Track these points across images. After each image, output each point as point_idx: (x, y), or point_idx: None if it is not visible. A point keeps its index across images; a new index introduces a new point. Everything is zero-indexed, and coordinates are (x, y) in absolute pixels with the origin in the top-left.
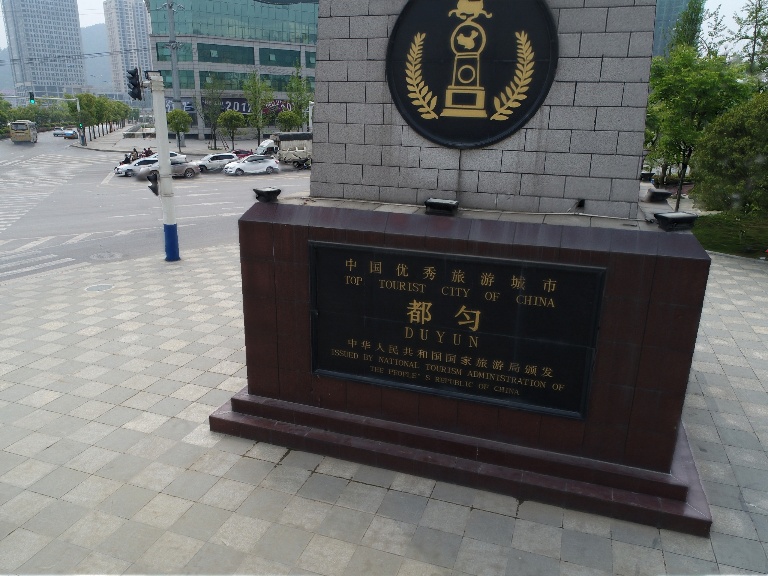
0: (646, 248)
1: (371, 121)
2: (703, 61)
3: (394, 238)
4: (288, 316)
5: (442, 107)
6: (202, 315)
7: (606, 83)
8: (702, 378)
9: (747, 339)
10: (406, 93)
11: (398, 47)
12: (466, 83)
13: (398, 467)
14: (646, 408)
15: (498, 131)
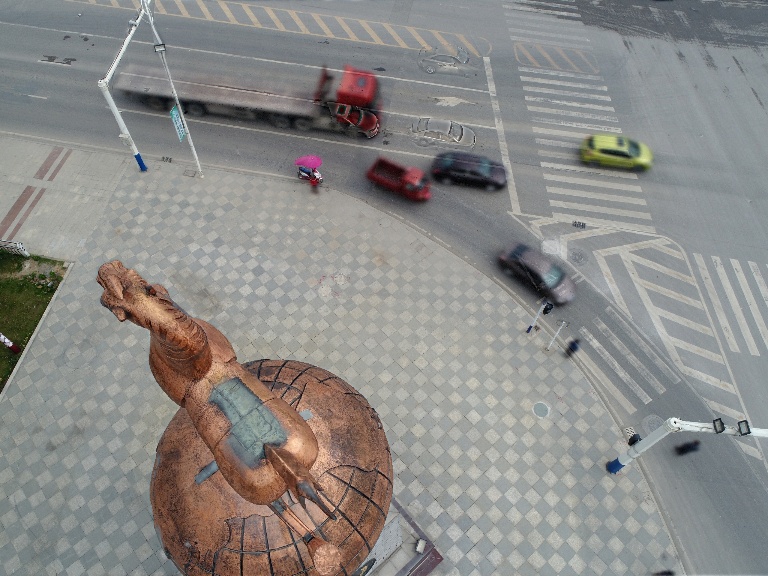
0: None
1: None
2: None
3: None
4: None
5: None
6: (458, 453)
7: None
8: None
9: None
10: None
11: None
12: None
13: None
14: None
15: None
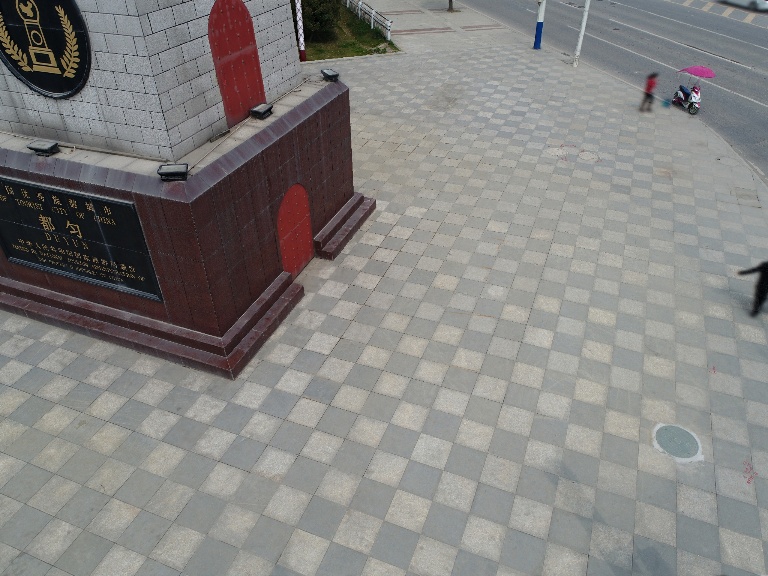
0: None
1: None
2: None
3: None
4: None
5: None
6: (449, 338)
7: None
8: None
9: None
10: None
11: None
12: None
13: None
14: None
15: None
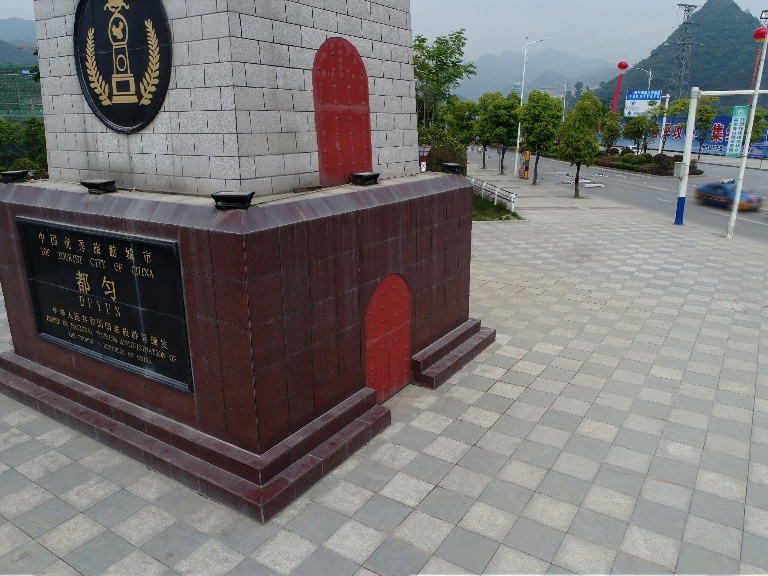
0: None
1: None
2: None
3: None
4: None
5: None
6: (611, 507)
7: None
8: None
9: None
10: None
11: None
12: None
13: None
14: None
15: None
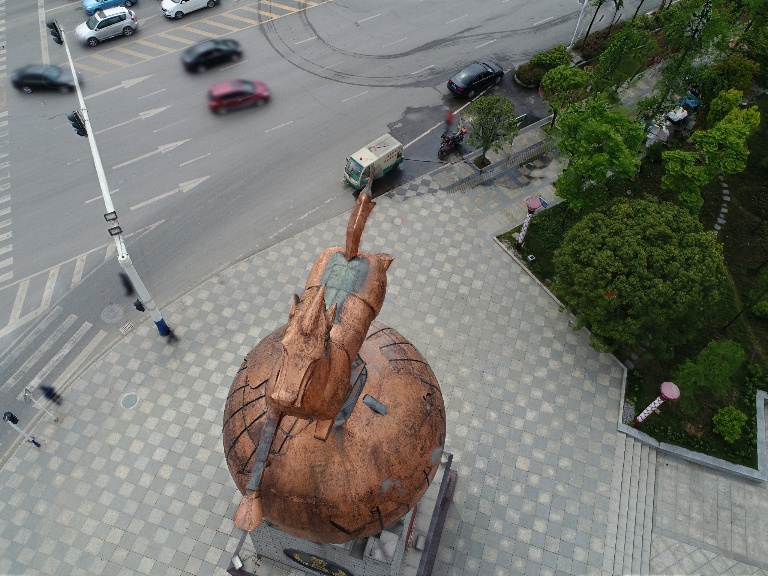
0: None
1: None
2: (604, 131)
3: None
4: None
5: None
6: (203, 452)
7: None
8: (460, 530)
9: (506, 477)
10: None
11: None
12: None
13: None
14: None
15: None
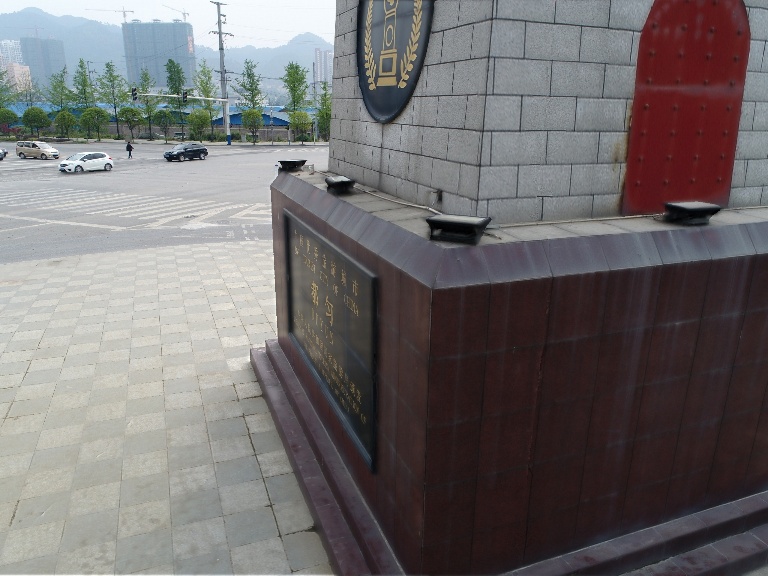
0: (400, 257)
1: (350, 95)
2: None
3: (305, 213)
4: (283, 277)
5: (378, 76)
6: None
7: (462, 27)
8: None
9: None
10: (364, 63)
11: (363, 14)
12: (389, 46)
13: (285, 444)
14: (403, 487)
15: (401, 101)
